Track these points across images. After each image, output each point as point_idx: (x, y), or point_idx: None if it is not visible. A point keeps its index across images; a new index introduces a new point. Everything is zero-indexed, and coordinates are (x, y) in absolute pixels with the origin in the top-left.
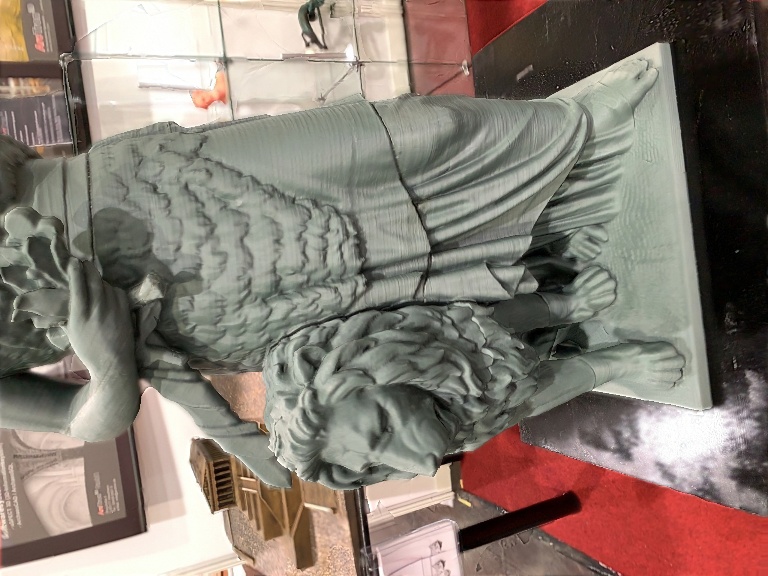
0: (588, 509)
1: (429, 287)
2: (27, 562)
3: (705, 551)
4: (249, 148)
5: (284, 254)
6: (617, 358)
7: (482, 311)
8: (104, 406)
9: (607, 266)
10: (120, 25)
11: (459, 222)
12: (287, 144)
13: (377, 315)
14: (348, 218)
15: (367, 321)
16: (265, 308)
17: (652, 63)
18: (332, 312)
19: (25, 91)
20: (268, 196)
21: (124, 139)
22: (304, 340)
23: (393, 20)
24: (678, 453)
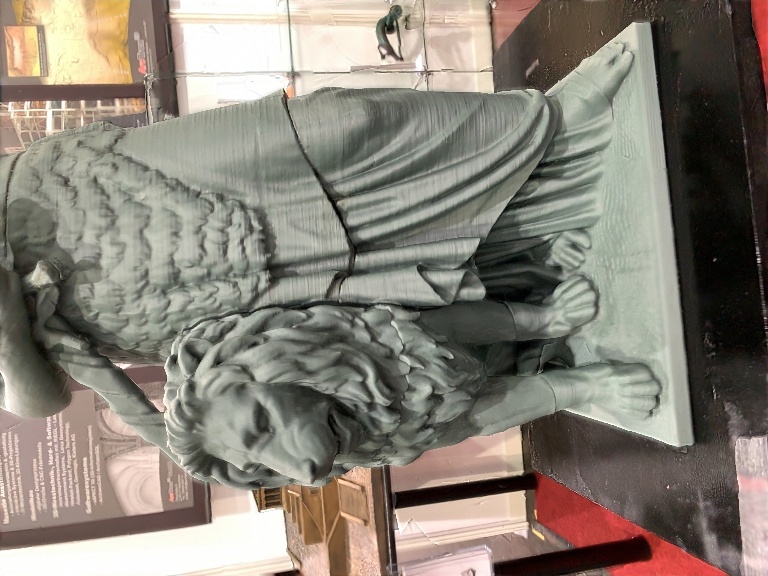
0: (658, 558)
1: (346, 287)
2: (106, 537)
3: None
4: (157, 143)
5: (181, 246)
6: (584, 379)
7: (404, 315)
8: (11, 383)
9: (590, 276)
10: (195, 45)
11: (387, 221)
12: (192, 139)
13: (278, 312)
14: (253, 213)
15: (265, 318)
16: (163, 299)
17: (629, 46)
18: (232, 307)
19: (128, 110)
20: (169, 189)
21: None
22: (199, 333)
23: (480, 29)
24: (663, 495)
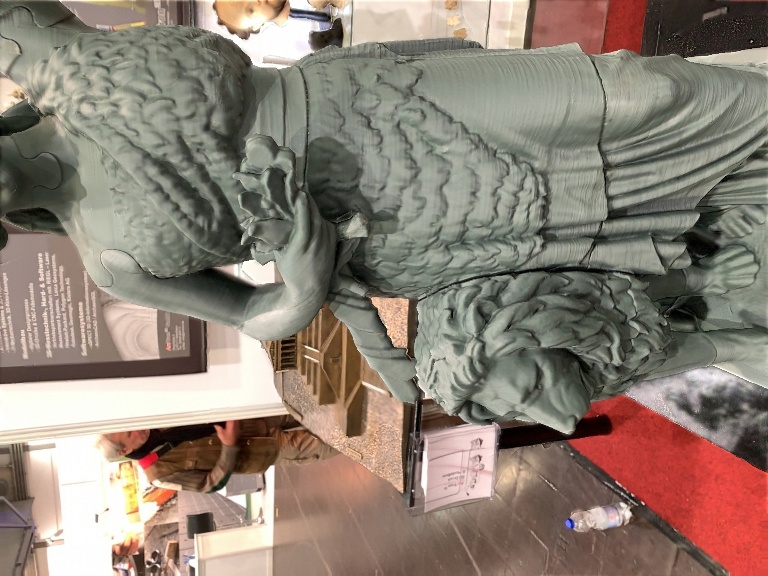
0: (618, 434)
1: (595, 254)
2: (101, 378)
3: (726, 497)
4: (464, 93)
5: (477, 207)
6: (742, 343)
7: (639, 285)
8: (290, 321)
9: (754, 248)
10: None
11: (638, 193)
12: (503, 95)
13: (546, 277)
14: (542, 178)
15: (537, 282)
16: (448, 255)
17: None
18: (506, 267)
19: None
20: (474, 147)
21: (336, 58)
22: (477, 291)
23: None
24: (767, 436)
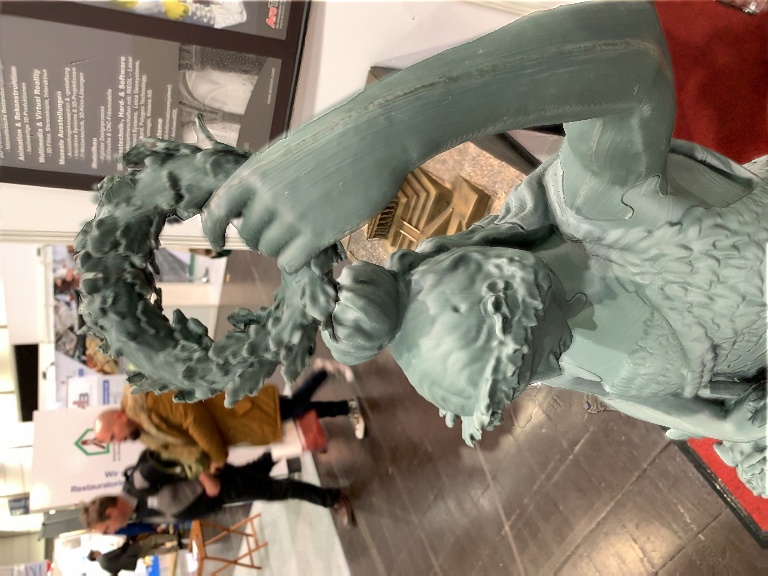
0: None
1: None
2: None
3: None
4: None
5: None
6: None
7: None
8: None
9: None
10: None
11: None
12: None
13: None
14: None
15: None
16: None
17: None
18: None
19: None
20: None
21: None
22: None
23: None
24: None
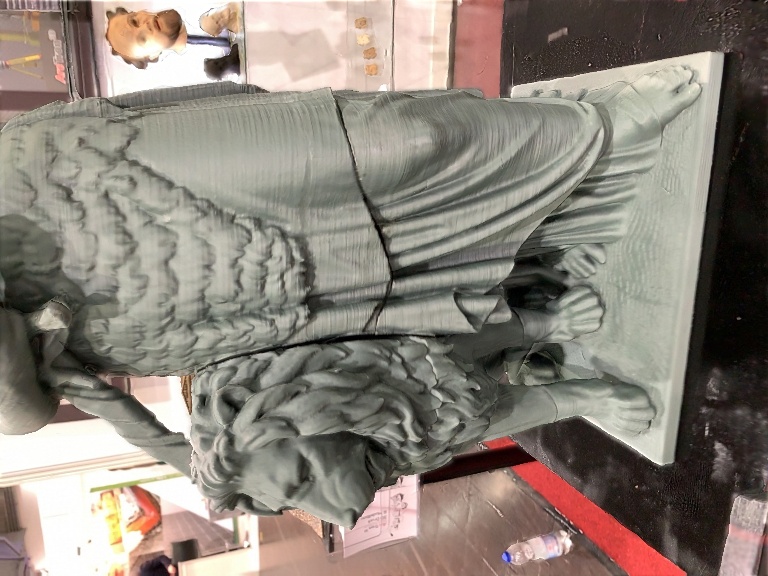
0: None
1: (383, 319)
2: None
3: None
4: (184, 154)
5: (215, 282)
6: (585, 396)
7: (439, 349)
8: (8, 422)
9: (599, 290)
10: None
11: (430, 247)
12: (229, 154)
13: (317, 351)
14: (295, 243)
15: (304, 359)
16: (190, 336)
17: (697, 76)
18: (266, 344)
19: None
20: (201, 214)
21: (43, 119)
22: (231, 373)
23: None
24: (630, 491)
